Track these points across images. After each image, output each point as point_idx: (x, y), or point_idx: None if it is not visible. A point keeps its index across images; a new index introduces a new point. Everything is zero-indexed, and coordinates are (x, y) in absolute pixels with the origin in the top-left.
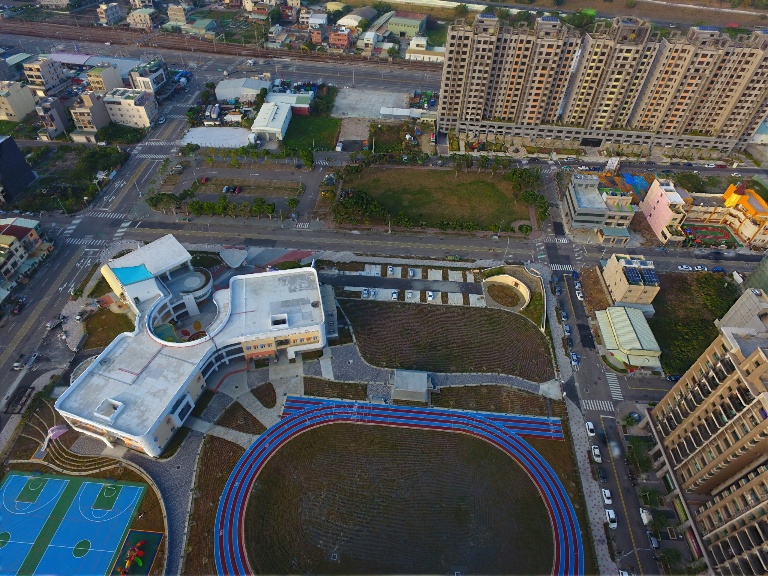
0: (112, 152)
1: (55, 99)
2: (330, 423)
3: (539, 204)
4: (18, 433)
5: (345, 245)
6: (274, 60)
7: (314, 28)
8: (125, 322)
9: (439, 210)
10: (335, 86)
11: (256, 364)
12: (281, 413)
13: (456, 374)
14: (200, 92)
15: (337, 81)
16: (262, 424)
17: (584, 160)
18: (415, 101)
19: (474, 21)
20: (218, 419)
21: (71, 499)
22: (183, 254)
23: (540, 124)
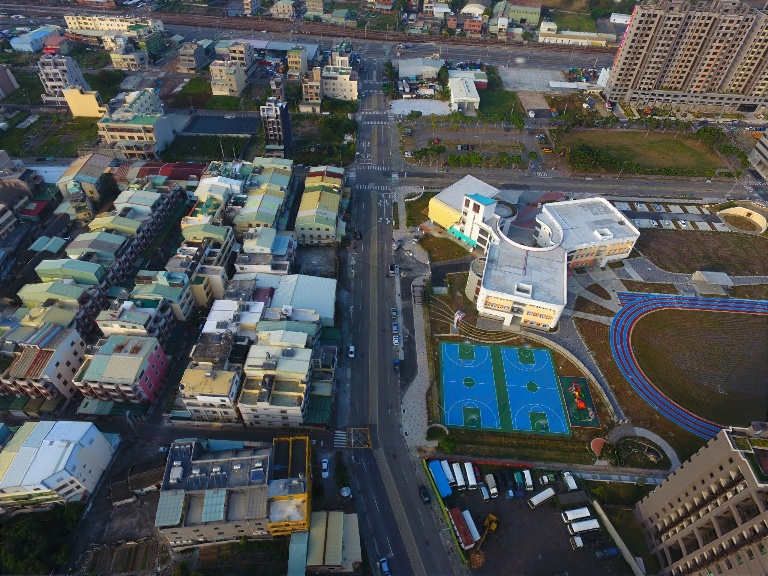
0: (343, 119)
1: (282, 75)
2: (662, 309)
3: (739, 154)
4: (427, 317)
5: (588, 188)
6: (421, 44)
7: (450, 15)
8: (452, 243)
9: (648, 162)
10: (492, 65)
11: (577, 271)
12: (620, 303)
13: (738, 277)
14: (377, 71)
15: (490, 61)
16: (610, 310)
17: (747, 122)
18: (573, 76)
19: (659, 1)
20: (574, 307)
21: (500, 358)
22: (491, 189)
23: (705, 92)
